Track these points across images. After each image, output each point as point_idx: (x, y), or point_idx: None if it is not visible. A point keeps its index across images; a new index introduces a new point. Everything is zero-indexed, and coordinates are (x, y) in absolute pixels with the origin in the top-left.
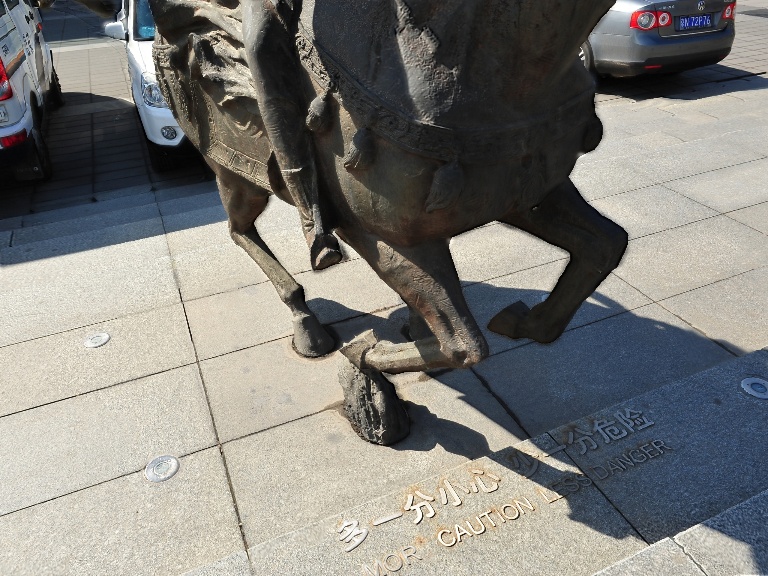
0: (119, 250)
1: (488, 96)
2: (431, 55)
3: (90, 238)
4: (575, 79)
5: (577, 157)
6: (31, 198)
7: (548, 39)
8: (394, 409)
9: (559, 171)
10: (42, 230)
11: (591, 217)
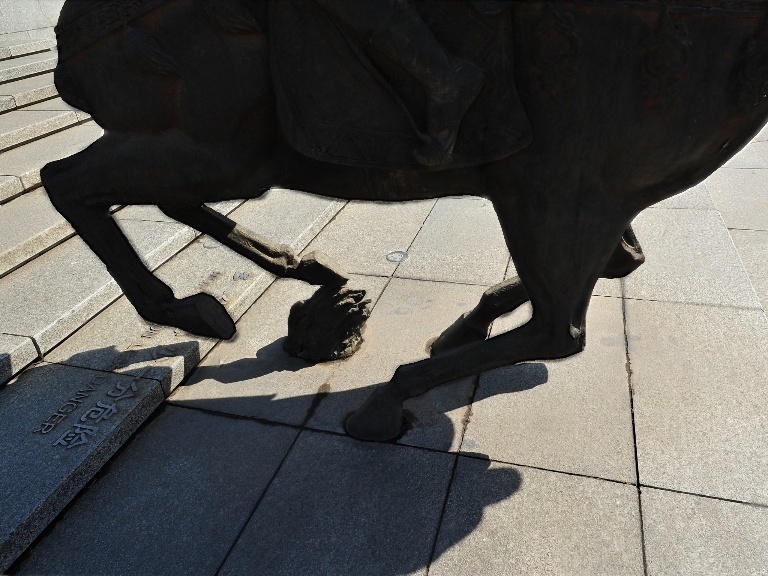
0: None
1: None
2: None
3: None
4: None
5: None
6: None
7: None
8: (291, 318)
9: None
10: None
11: None
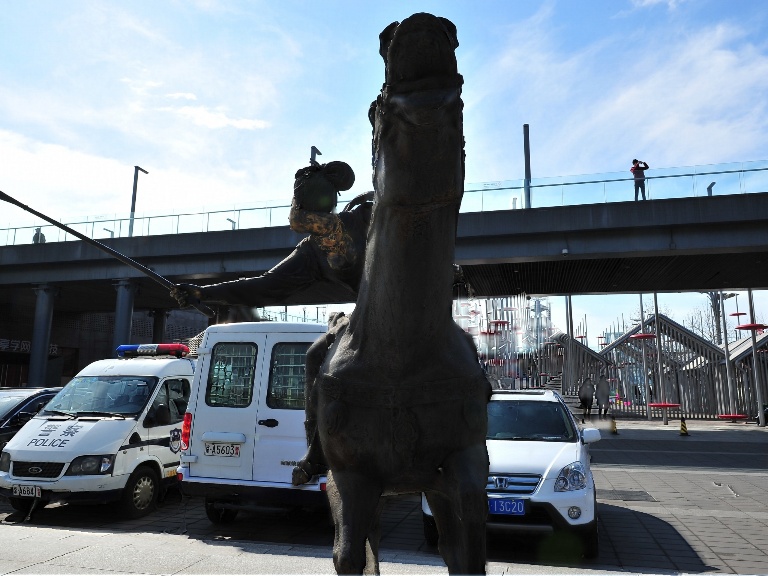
0: (328, 561)
1: (370, 366)
2: (348, 344)
3: (326, 557)
4: (444, 367)
5: (466, 429)
6: (332, 540)
7: (388, 331)
8: None
9: (438, 431)
10: (310, 551)
11: (460, 472)
